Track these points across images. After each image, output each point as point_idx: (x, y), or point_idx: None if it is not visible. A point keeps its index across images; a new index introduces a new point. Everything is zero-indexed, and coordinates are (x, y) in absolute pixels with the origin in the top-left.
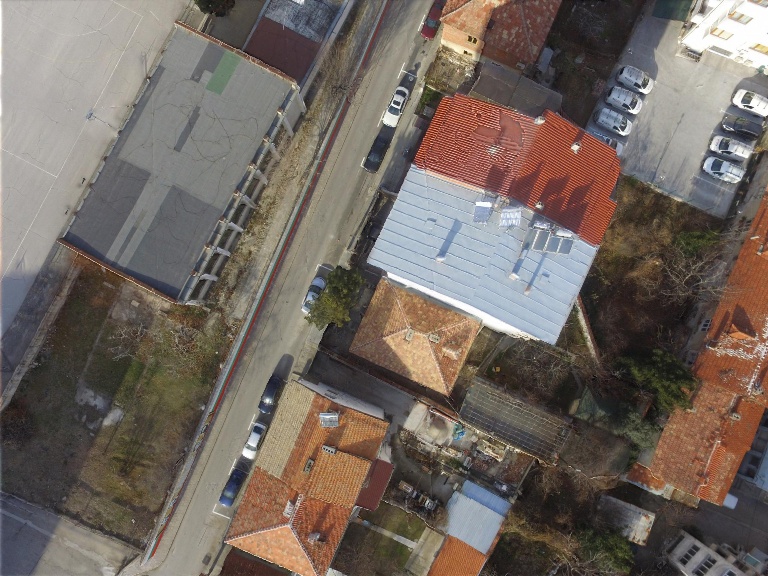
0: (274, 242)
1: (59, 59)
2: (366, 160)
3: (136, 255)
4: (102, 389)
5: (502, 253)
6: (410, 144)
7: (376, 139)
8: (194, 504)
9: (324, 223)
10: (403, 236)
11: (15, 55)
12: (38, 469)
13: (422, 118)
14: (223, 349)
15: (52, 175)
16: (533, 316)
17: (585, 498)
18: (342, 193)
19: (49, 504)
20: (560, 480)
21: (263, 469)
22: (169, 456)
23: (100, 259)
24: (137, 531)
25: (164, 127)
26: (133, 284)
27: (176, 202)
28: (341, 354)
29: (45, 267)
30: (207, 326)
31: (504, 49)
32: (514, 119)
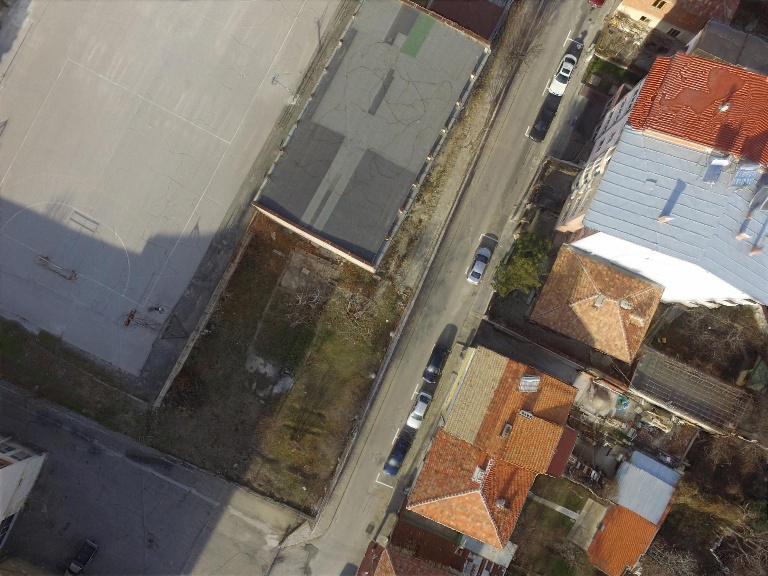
0: (445, 210)
1: (232, 25)
2: (533, 129)
3: (331, 218)
4: (272, 357)
5: (730, 213)
6: (576, 113)
7: (543, 108)
8: (357, 473)
9: (488, 192)
10: (620, 197)
11: (188, 21)
12: (210, 436)
13: (588, 87)
14: (393, 317)
15: (225, 141)
16: (755, 278)
17: (752, 470)
18: (506, 162)
19: (220, 471)
20: (733, 451)
21: (446, 436)
22: (339, 424)
23: (296, 222)
24: (308, 498)
25: (358, 90)
26: (303, 252)
27: (371, 165)
28: (506, 324)
29: (219, 234)
30: (377, 294)
31: (697, 13)
32: (743, 77)
